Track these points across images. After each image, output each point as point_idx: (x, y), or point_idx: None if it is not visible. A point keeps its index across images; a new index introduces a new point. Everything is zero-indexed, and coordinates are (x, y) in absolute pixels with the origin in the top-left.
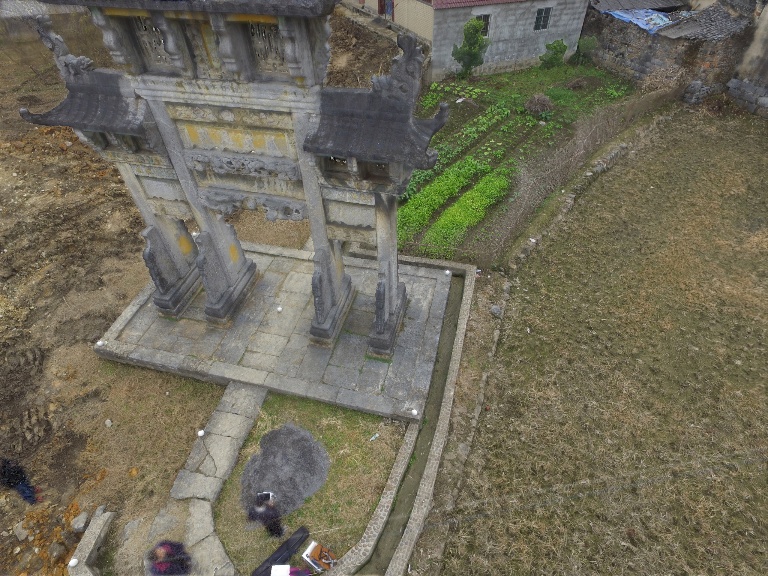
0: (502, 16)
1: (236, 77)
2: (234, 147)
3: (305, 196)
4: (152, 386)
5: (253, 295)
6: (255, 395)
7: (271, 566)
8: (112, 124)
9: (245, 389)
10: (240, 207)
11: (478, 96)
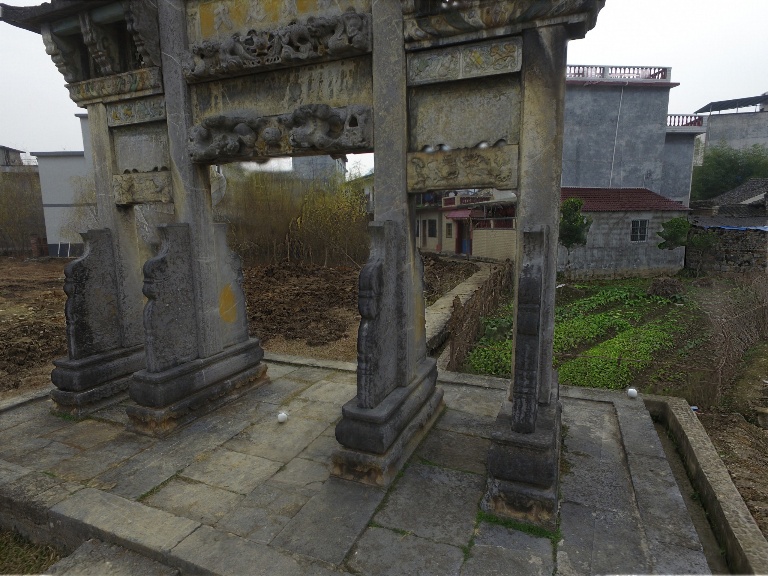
0: (594, 224)
1: None
2: (264, 24)
3: (373, 88)
4: None
5: (241, 400)
6: None
7: None
8: None
9: (114, 562)
10: (251, 150)
11: (580, 289)
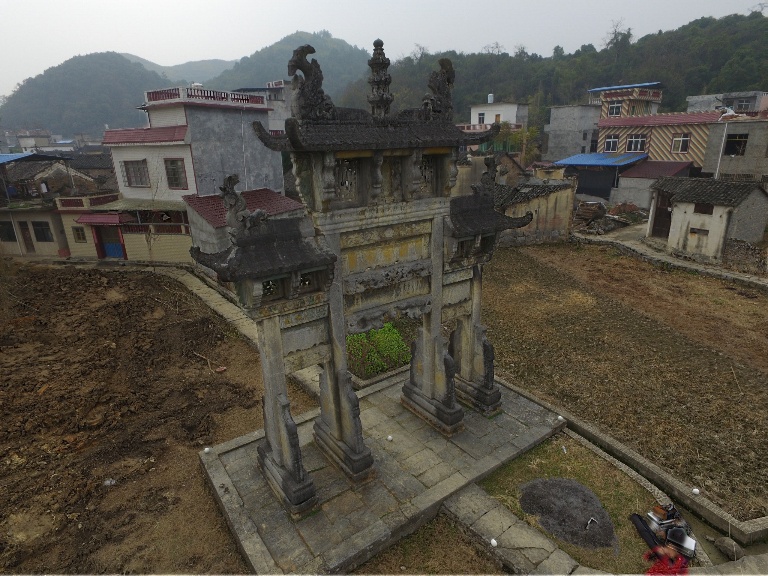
0: None
1: (410, 196)
2: (384, 262)
3: (432, 288)
4: (382, 575)
5: None
6: (474, 492)
7: (663, 547)
8: (311, 260)
9: (462, 496)
10: None
11: None
